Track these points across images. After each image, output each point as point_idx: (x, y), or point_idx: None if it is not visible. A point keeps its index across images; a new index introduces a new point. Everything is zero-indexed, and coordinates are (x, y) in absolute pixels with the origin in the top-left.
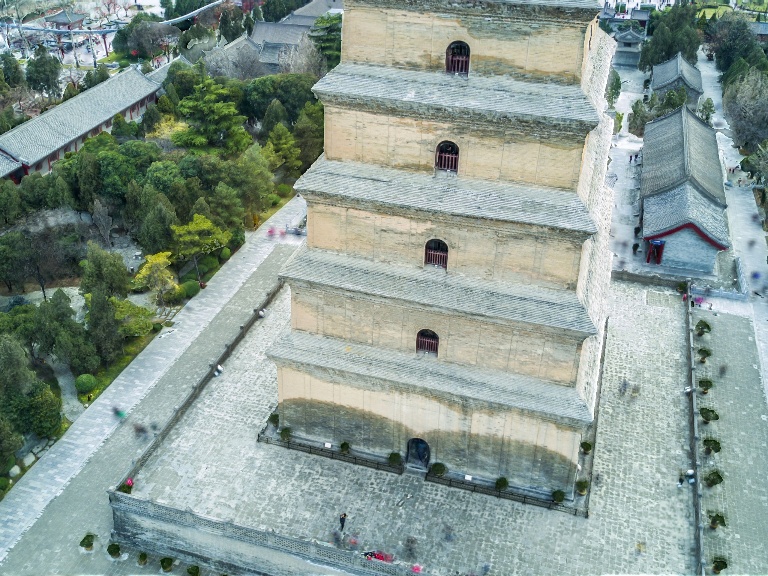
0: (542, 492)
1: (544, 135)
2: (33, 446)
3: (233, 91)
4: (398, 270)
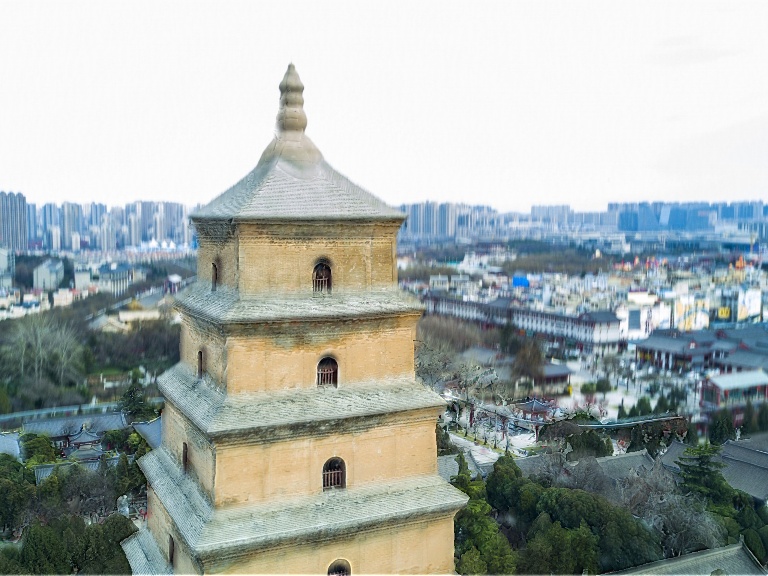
0: None
1: None
2: None
3: (524, 494)
4: None
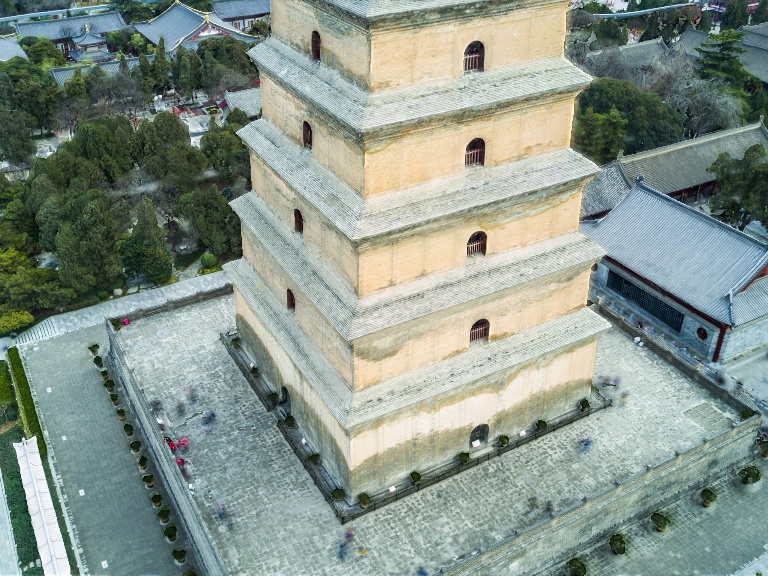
0: (337, 485)
1: (345, 134)
2: (142, 283)
3: None
4: (282, 229)
